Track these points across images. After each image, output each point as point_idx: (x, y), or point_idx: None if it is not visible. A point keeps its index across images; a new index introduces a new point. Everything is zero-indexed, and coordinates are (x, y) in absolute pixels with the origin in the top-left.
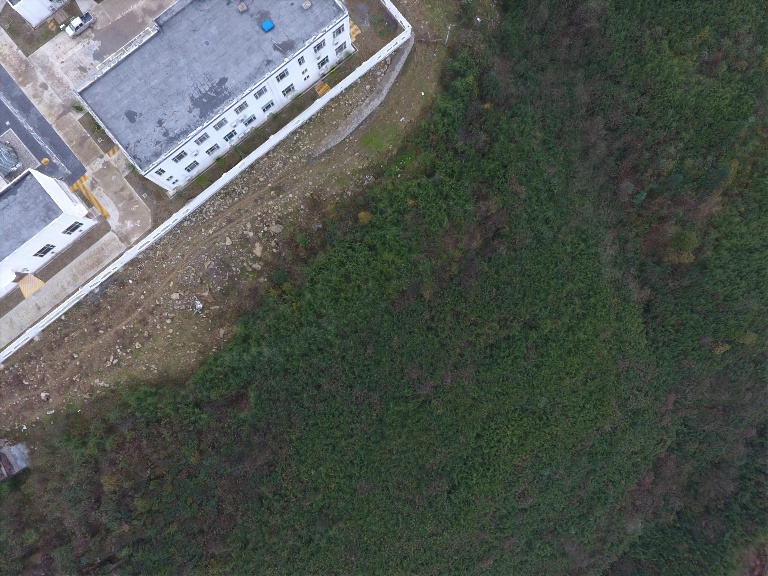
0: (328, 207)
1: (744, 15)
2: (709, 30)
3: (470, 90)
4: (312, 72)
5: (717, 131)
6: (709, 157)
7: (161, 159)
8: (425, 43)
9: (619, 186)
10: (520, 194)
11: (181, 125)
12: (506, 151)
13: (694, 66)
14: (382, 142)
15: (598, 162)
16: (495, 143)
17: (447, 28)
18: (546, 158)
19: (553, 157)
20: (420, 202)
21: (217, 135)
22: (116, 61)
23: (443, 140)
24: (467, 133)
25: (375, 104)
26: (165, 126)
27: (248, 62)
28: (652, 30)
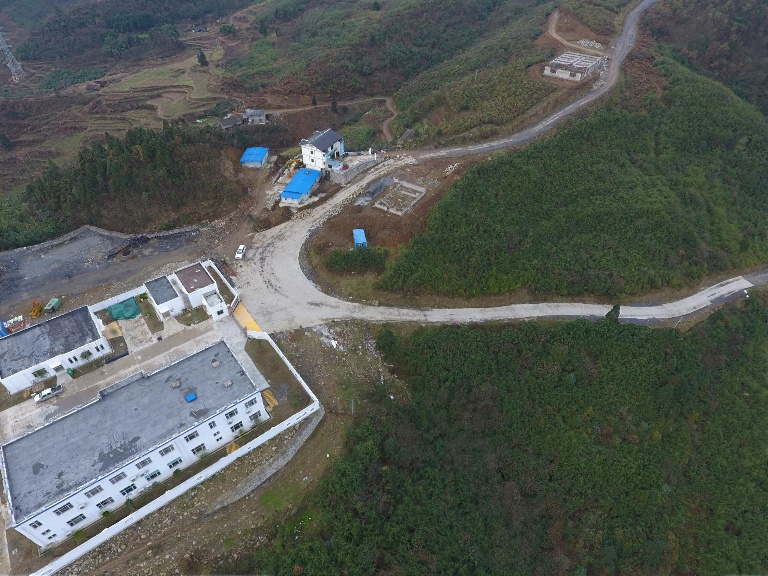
0: (203, 572)
1: (619, 399)
2: (594, 409)
3: (369, 453)
4: (225, 434)
5: (635, 500)
6: (638, 528)
7: (40, 510)
8: (335, 414)
9: (554, 559)
10: (429, 564)
11: (78, 477)
12: (412, 514)
13: (591, 438)
14: (282, 501)
15: (526, 530)
16: (399, 505)
17: (358, 403)
18: (462, 523)
19: (471, 523)
20: (309, 569)
21: (113, 488)
22: (52, 421)
23: (343, 500)
24: (368, 494)
25: (280, 464)
26: (63, 478)
27: (164, 425)
28: (544, 408)
